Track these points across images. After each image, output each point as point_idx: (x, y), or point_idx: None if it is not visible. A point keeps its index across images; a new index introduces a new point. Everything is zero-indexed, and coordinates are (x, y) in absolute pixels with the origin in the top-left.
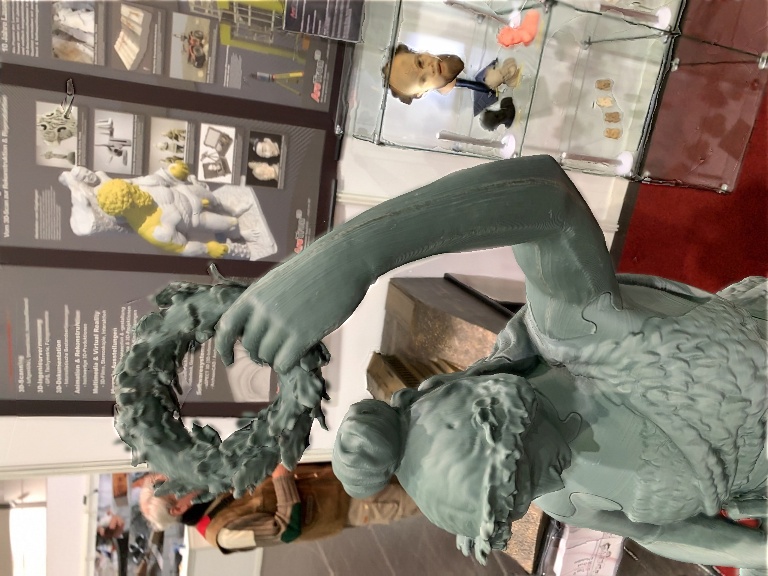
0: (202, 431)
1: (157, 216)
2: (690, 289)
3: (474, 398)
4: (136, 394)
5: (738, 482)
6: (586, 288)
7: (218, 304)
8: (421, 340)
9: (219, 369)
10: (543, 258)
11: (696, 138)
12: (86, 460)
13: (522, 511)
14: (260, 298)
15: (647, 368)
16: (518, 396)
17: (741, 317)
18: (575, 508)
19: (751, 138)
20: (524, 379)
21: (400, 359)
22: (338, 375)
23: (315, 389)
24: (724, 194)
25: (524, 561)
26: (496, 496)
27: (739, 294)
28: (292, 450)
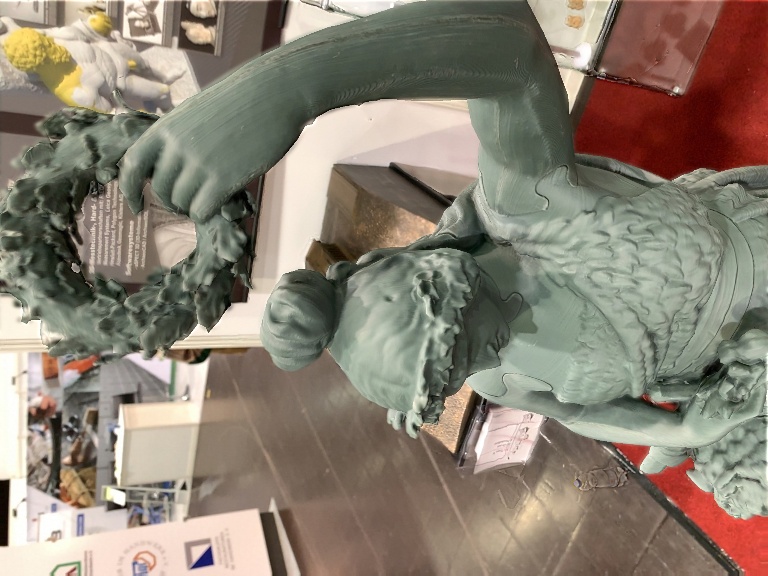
0: (105, 285)
1: (76, 76)
2: (644, 174)
3: (415, 271)
4: (22, 239)
5: (665, 367)
6: (543, 158)
7: (122, 137)
8: (362, 229)
9: (150, 249)
10: (502, 119)
11: (655, 37)
12: (7, 338)
13: (456, 387)
14: (173, 130)
15: (595, 248)
16: (462, 270)
17: (693, 202)
18: (506, 388)
19: (709, 39)
20: (469, 254)
21: (340, 248)
22: (276, 262)
23: (238, 241)
24: (675, 97)
25: (448, 442)
26: (432, 370)
27: (689, 184)
28: (210, 308)
